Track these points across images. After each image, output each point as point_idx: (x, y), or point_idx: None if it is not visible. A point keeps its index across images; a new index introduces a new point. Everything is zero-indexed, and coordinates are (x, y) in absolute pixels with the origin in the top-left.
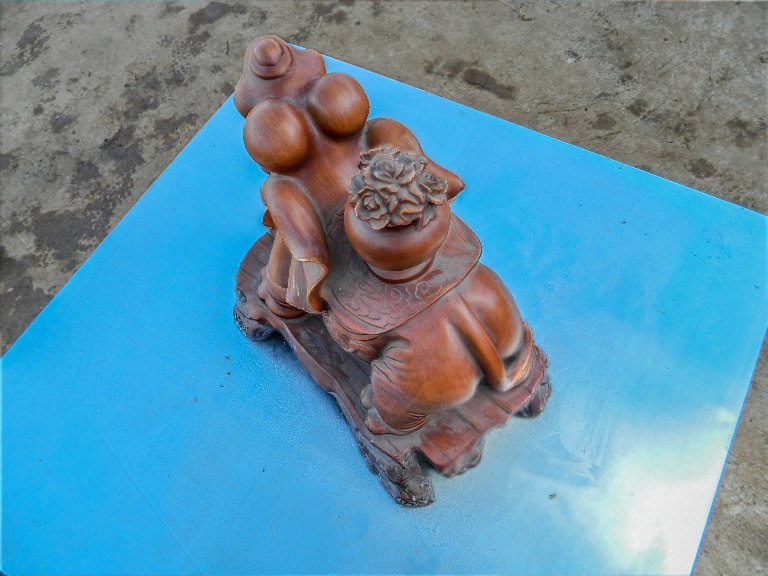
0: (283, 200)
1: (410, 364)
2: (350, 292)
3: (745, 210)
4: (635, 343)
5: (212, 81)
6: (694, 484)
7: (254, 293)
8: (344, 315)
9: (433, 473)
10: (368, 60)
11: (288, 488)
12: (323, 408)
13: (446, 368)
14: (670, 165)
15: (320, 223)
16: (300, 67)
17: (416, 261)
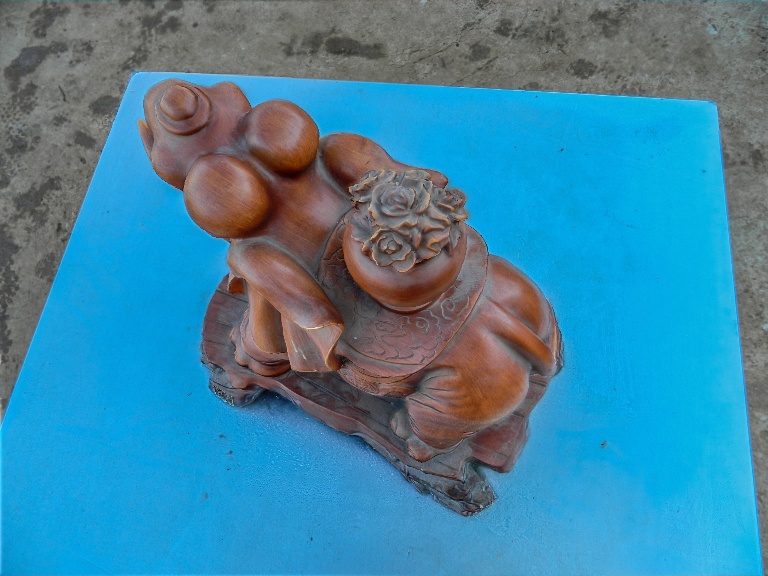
0: (264, 268)
1: (461, 390)
2: (368, 338)
3: (665, 100)
4: (619, 265)
5: (60, 135)
6: (723, 379)
7: (231, 361)
8: (369, 364)
9: (483, 469)
10: (221, 61)
11: (345, 546)
12: (346, 449)
13: (501, 380)
14: (554, 75)
15: (311, 276)
16: (222, 107)
17: (448, 286)
